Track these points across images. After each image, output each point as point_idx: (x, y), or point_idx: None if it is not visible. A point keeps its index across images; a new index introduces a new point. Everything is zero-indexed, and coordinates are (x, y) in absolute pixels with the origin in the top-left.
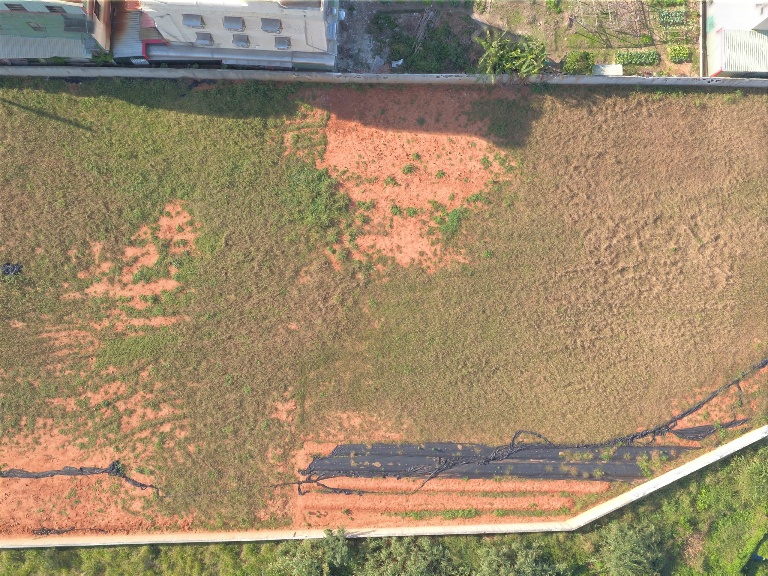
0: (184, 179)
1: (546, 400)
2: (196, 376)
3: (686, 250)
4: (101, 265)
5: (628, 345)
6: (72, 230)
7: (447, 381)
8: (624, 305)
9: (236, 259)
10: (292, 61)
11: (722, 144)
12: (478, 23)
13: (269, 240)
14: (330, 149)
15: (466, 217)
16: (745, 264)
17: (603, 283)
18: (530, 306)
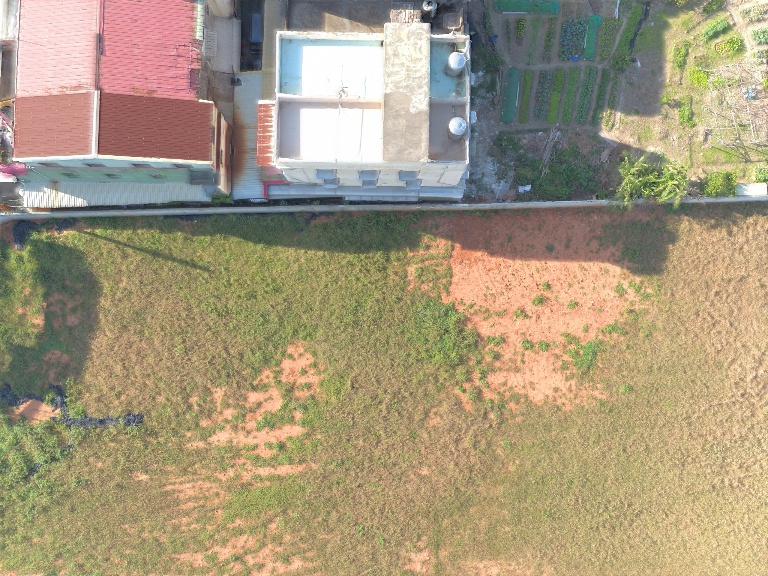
0: (306, 319)
1: (693, 544)
2: (325, 528)
3: None
4: (223, 412)
5: None
6: (193, 377)
7: (588, 526)
8: None
9: (363, 403)
10: (419, 196)
11: None
12: (607, 141)
13: (396, 381)
14: (456, 281)
15: (602, 349)
16: None
17: (750, 416)
18: (673, 443)
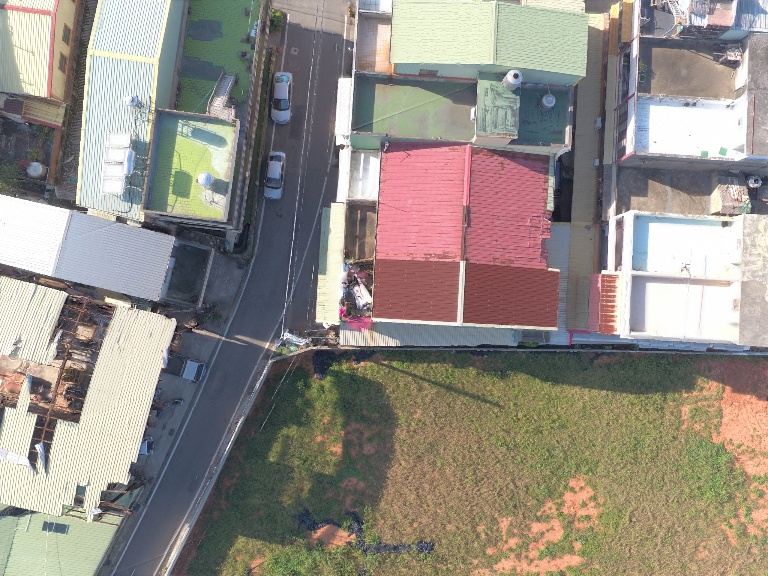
0: (589, 455)
1: None
2: None
3: None
4: (508, 541)
5: None
6: (482, 507)
7: None
8: None
9: (640, 536)
10: None
11: None
12: None
13: (671, 517)
14: (726, 422)
15: None
16: None
17: None
18: None
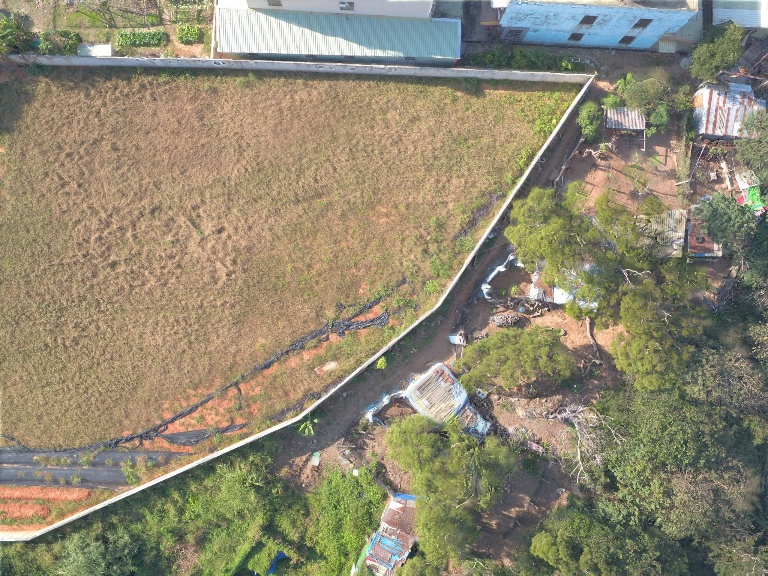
0: None
1: (21, 401)
2: None
3: (186, 243)
4: None
5: (115, 343)
6: None
7: None
8: (113, 301)
9: None
10: None
11: (232, 130)
12: None
13: None
14: None
15: None
16: (252, 258)
17: (91, 277)
18: (9, 301)
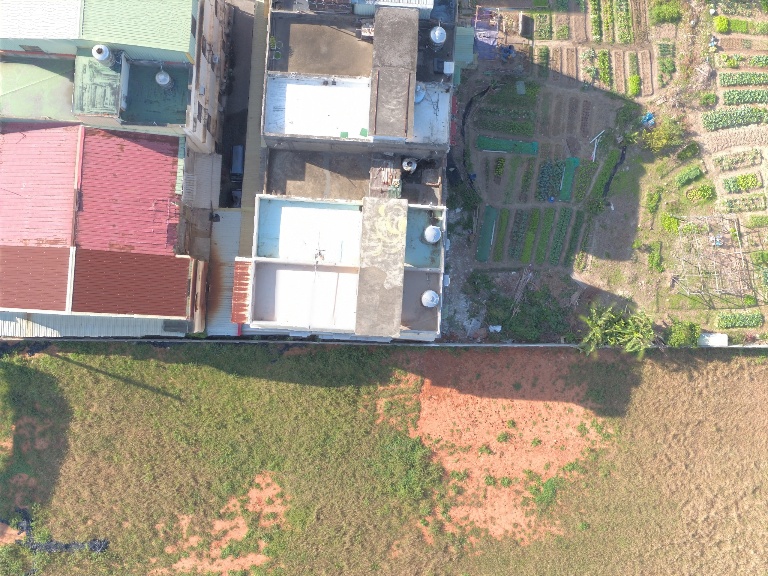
0: (275, 450)
1: None
2: None
3: None
4: (189, 539)
5: None
6: (160, 504)
7: None
8: None
9: (327, 534)
10: None
11: None
12: (578, 283)
13: (361, 514)
14: (424, 416)
15: (562, 487)
16: None
17: (700, 556)
18: None
